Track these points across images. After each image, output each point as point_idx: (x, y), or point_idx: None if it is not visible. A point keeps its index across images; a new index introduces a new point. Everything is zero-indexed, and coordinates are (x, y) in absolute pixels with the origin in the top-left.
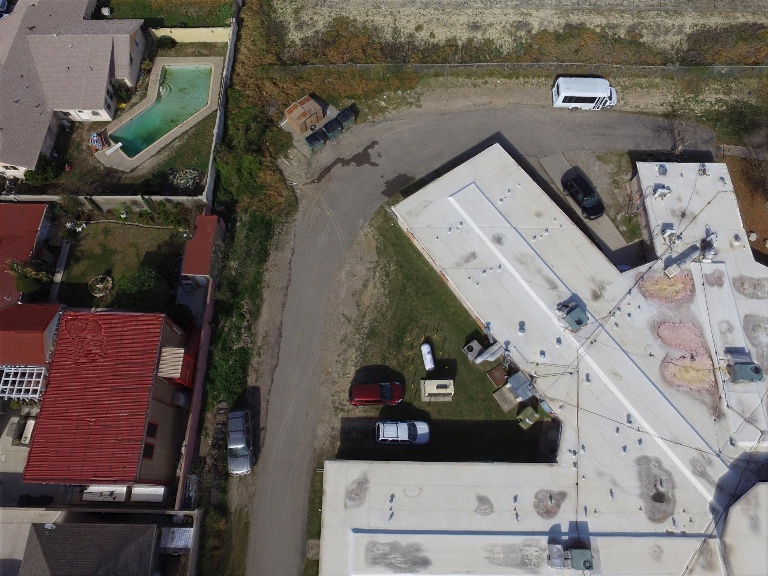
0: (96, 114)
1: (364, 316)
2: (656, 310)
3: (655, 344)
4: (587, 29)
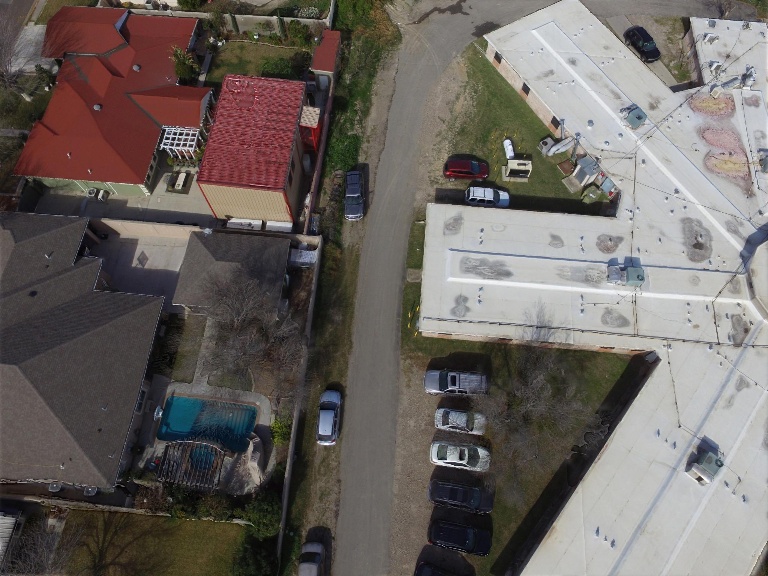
0: None
1: (456, 119)
2: (702, 120)
3: (700, 143)
4: None
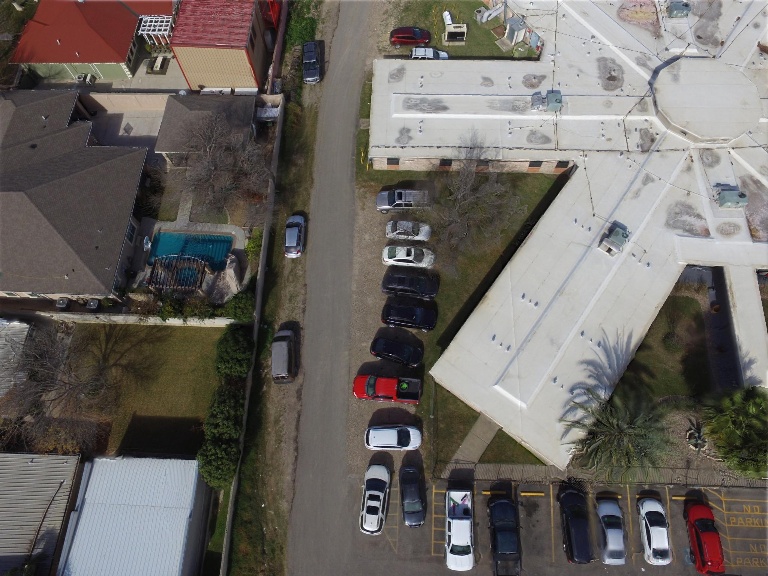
0: None
1: None
2: None
3: None
4: None
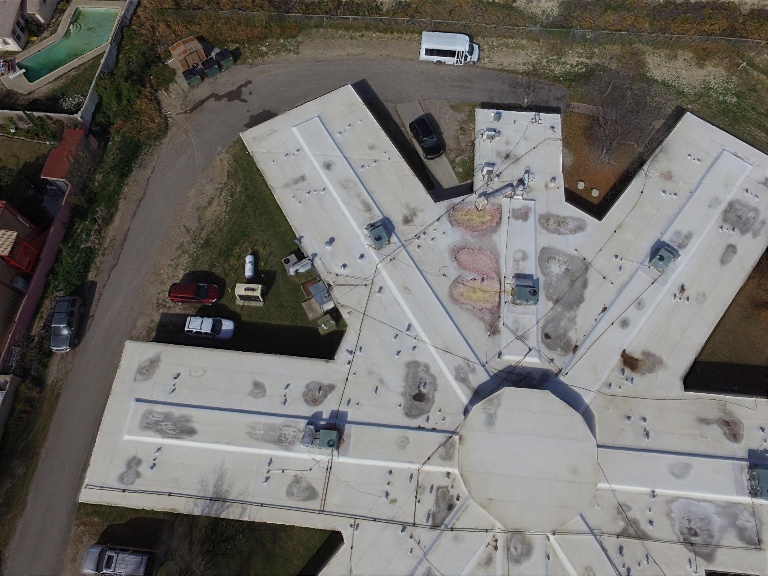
0: (7, 43)
1: (203, 229)
2: (459, 237)
3: (450, 266)
4: None
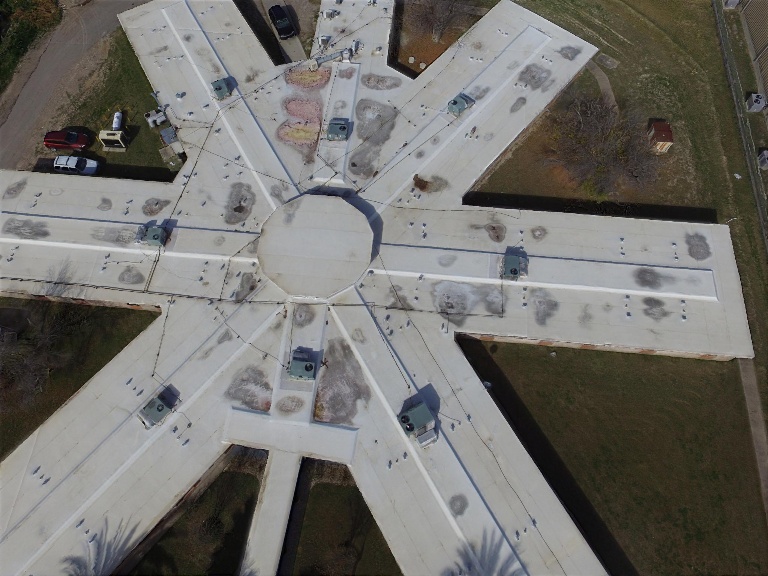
0: None
1: (82, 94)
2: (291, 91)
3: (281, 113)
4: None
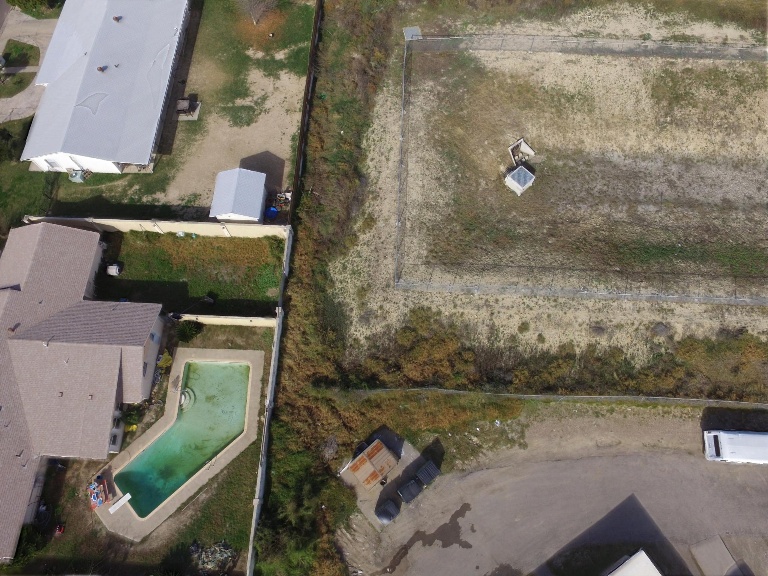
0: None
1: None
2: None
3: None
4: (750, 339)
